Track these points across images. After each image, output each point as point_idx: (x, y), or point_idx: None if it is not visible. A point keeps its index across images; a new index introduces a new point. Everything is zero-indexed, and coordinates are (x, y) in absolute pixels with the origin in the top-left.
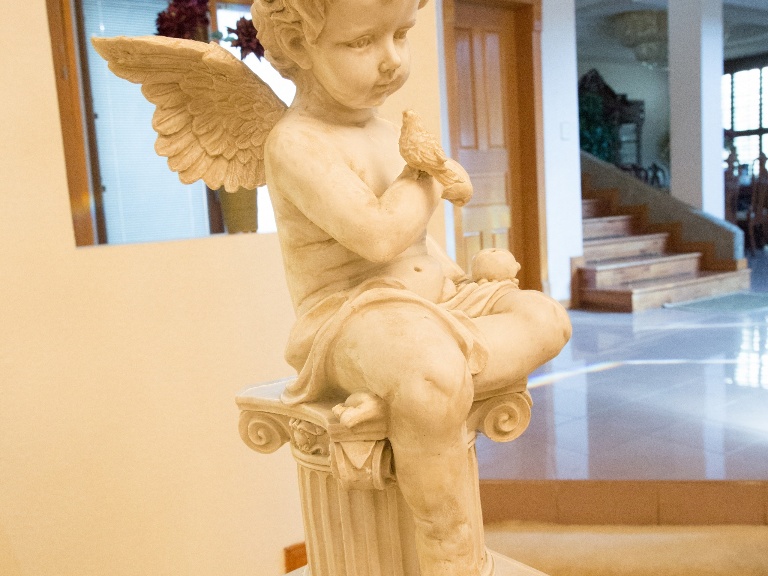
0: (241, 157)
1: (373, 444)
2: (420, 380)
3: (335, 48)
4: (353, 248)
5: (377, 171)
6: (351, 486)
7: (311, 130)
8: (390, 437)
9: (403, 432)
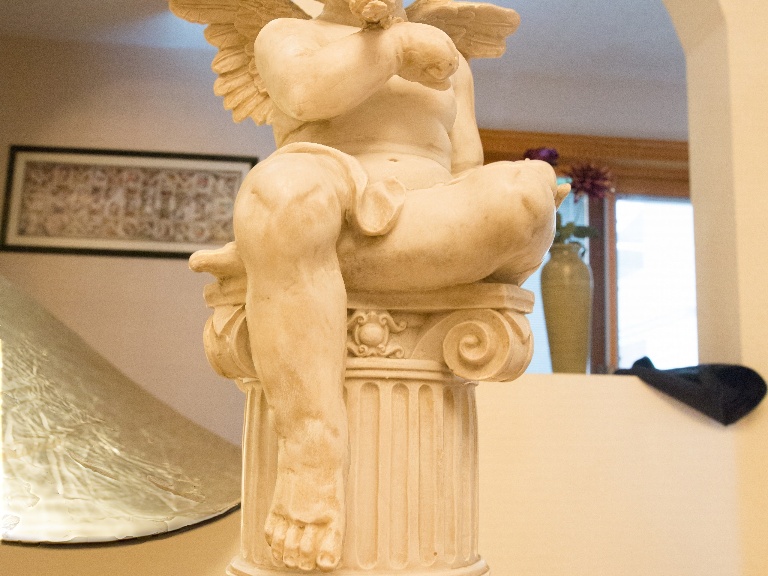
0: None
1: (239, 307)
2: (247, 193)
3: None
4: (282, 107)
5: None
6: (218, 364)
7: None
8: None
9: None
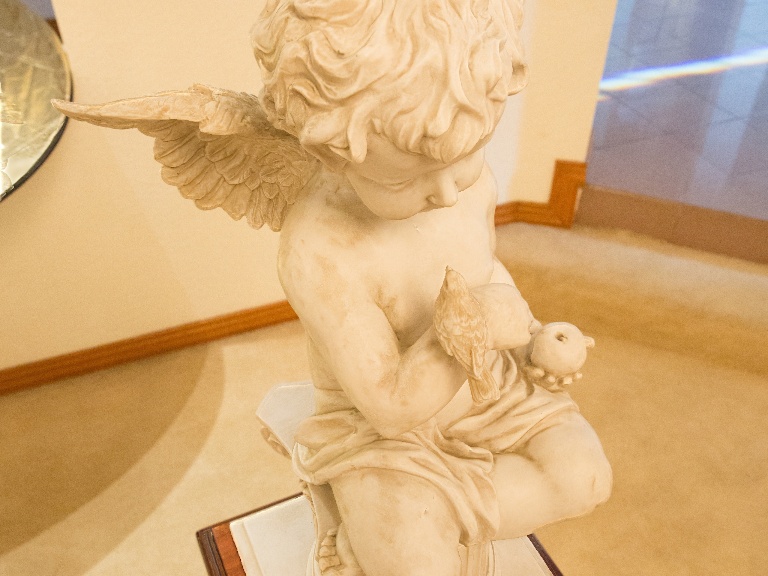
0: (266, 191)
1: None
2: None
3: (364, 180)
4: None
5: (414, 294)
6: None
7: (331, 250)
8: None
9: None
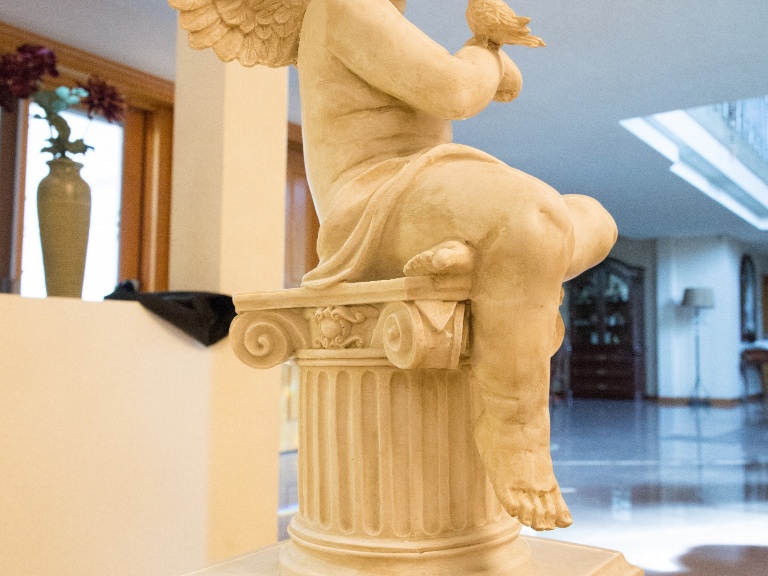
0: (260, 33)
1: (455, 304)
2: (535, 211)
3: None
4: (427, 99)
5: None
6: (424, 356)
7: None
8: (476, 295)
9: (500, 282)
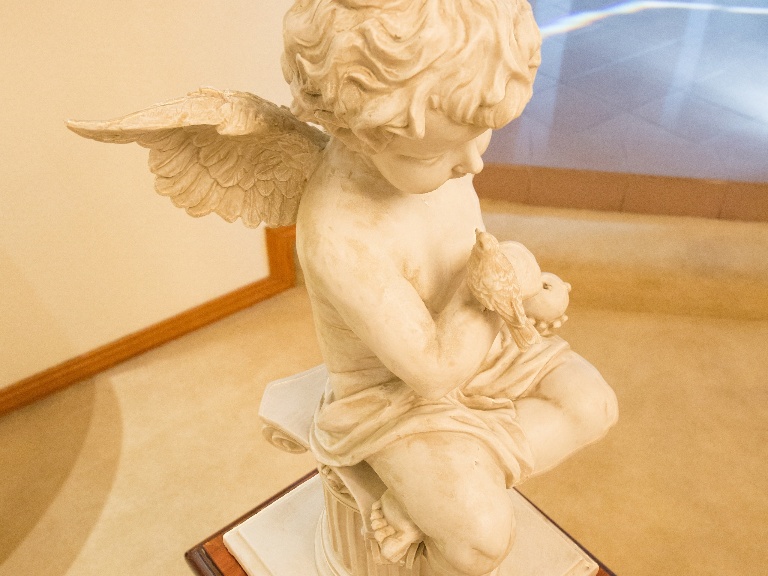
0: (261, 189)
1: (409, 546)
2: (467, 549)
3: (400, 158)
4: None
5: (433, 263)
6: None
7: (359, 232)
8: (426, 545)
9: (441, 557)
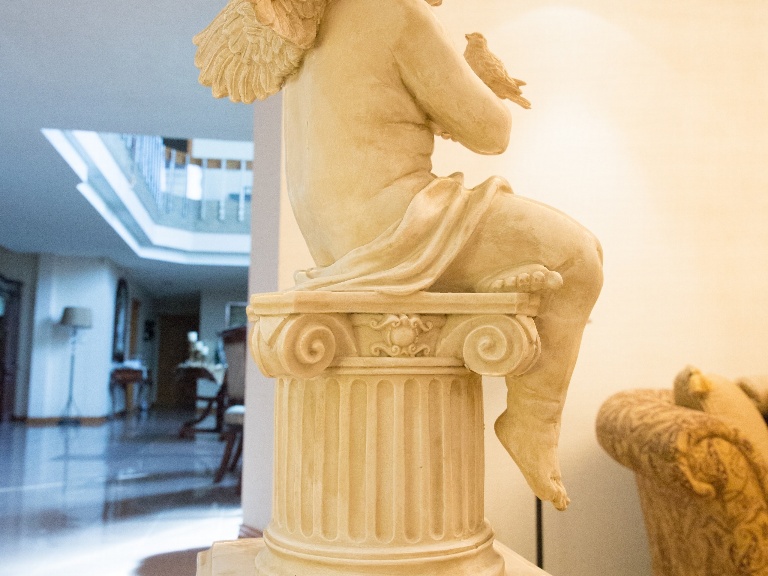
0: None
1: None
2: None
3: None
4: (484, 131)
5: None
6: (519, 365)
7: None
8: (543, 313)
9: (565, 303)
